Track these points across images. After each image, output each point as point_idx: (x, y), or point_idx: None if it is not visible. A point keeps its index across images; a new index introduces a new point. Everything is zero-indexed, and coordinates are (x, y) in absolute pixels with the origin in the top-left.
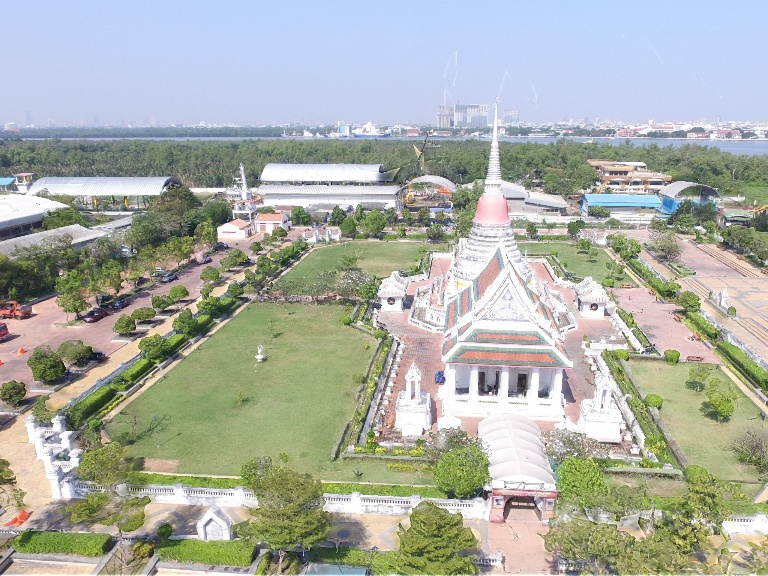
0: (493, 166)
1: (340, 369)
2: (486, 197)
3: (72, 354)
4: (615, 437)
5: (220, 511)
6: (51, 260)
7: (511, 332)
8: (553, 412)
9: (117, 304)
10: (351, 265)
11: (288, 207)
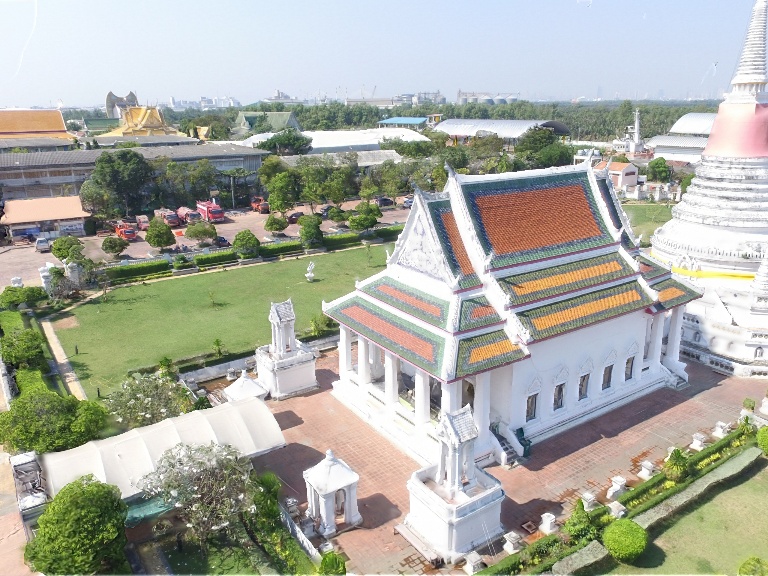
0: (747, 49)
1: None
2: (723, 107)
3: (188, 232)
4: (442, 548)
5: None
6: None
7: (419, 293)
8: (434, 456)
9: (325, 214)
10: None
11: (671, 162)
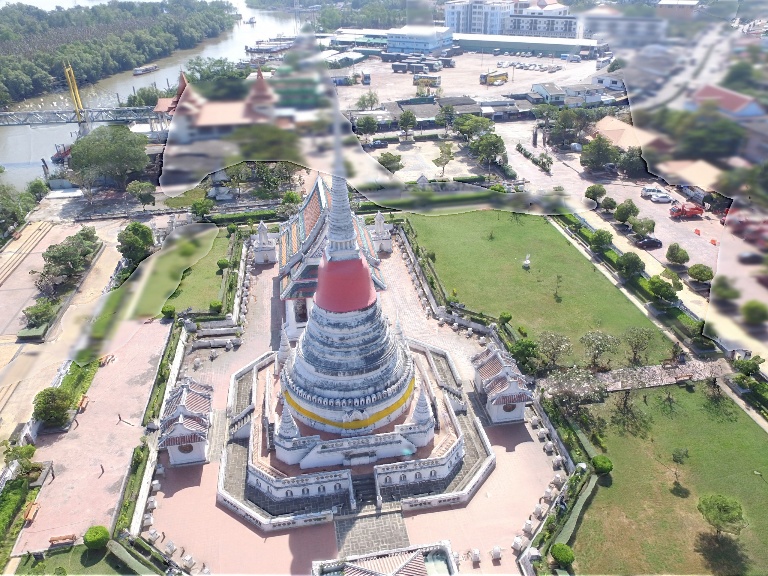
0: None
1: (457, 269)
2: None
3: None
4: None
5: (422, 178)
6: None
7: None
8: None
9: None
10: None
11: None
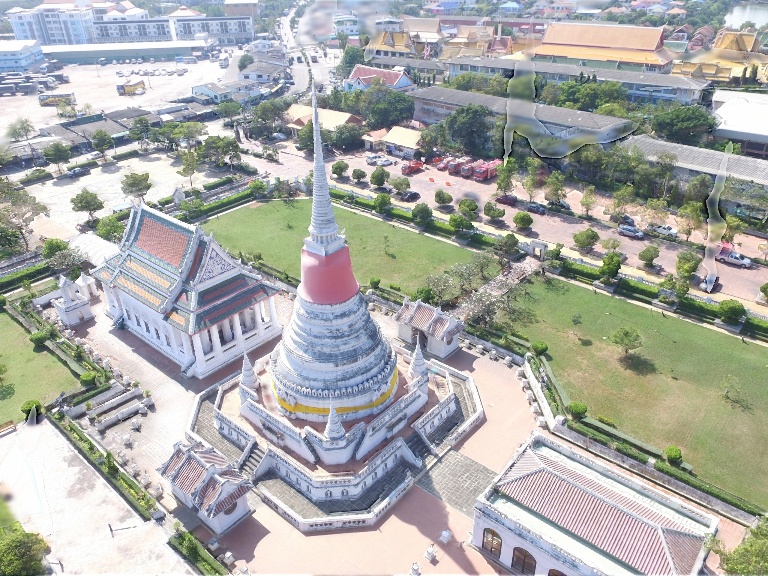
0: None
1: (290, 261)
2: None
3: None
4: None
5: None
6: (621, 166)
7: None
8: None
9: None
10: (676, 371)
11: None
